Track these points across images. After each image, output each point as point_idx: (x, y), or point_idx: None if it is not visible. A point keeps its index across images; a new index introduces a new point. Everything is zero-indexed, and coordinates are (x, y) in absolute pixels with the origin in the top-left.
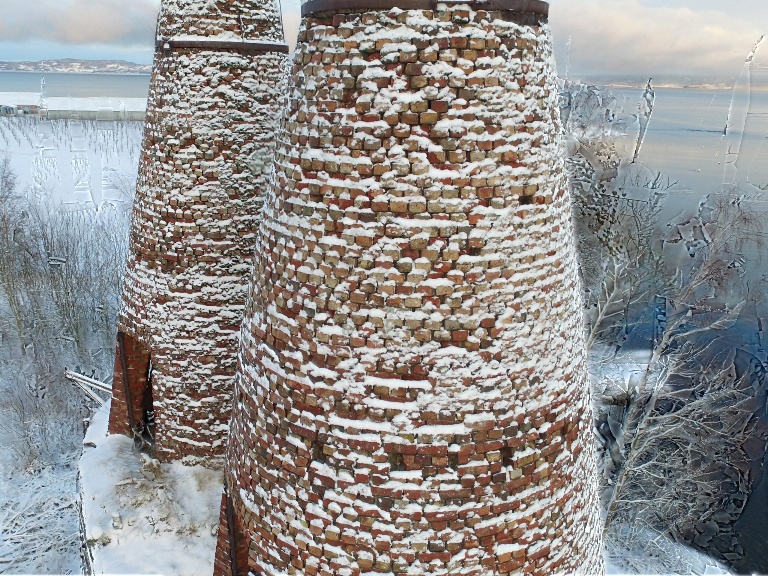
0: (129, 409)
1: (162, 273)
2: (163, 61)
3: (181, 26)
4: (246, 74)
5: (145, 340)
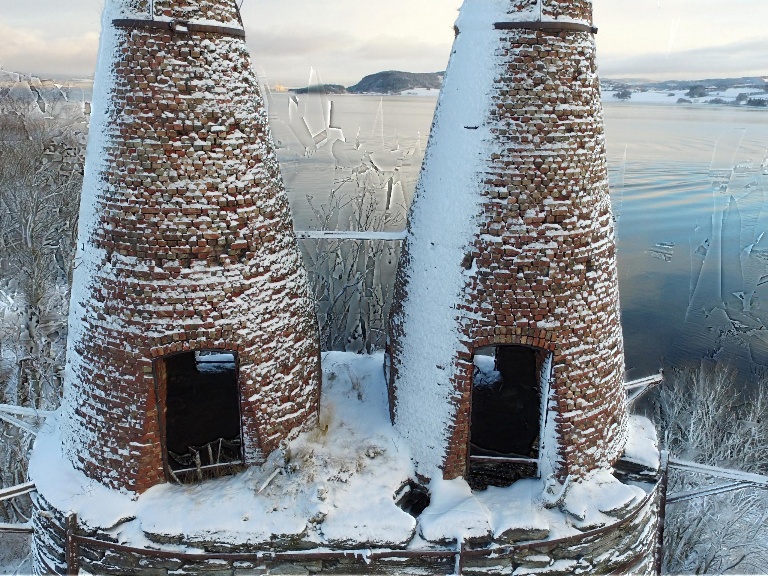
0: (162, 449)
1: (232, 265)
2: (178, 44)
3: (198, 9)
4: (249, 61)
5: (227, 341)
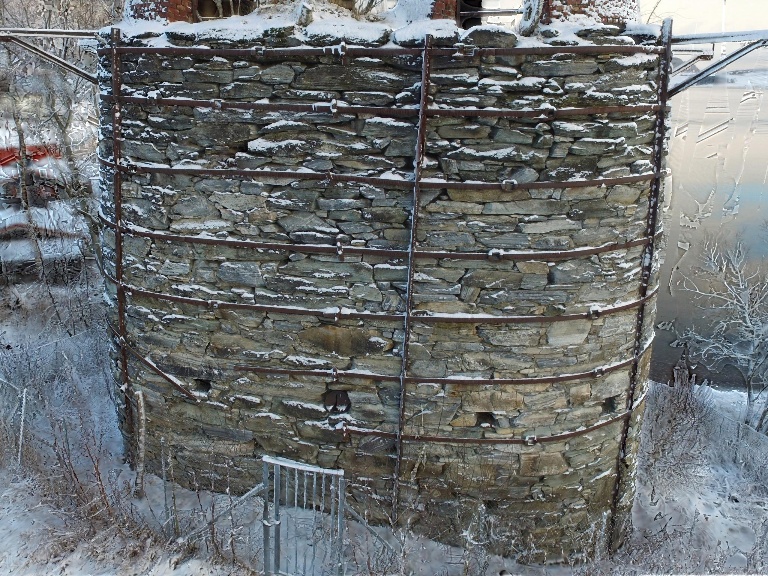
0: None
1: None
2: None
3: None
4: None
5: None
